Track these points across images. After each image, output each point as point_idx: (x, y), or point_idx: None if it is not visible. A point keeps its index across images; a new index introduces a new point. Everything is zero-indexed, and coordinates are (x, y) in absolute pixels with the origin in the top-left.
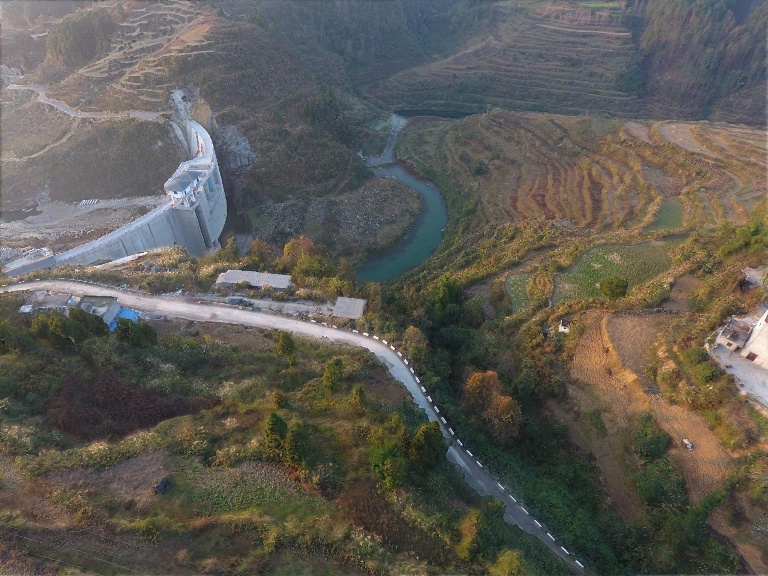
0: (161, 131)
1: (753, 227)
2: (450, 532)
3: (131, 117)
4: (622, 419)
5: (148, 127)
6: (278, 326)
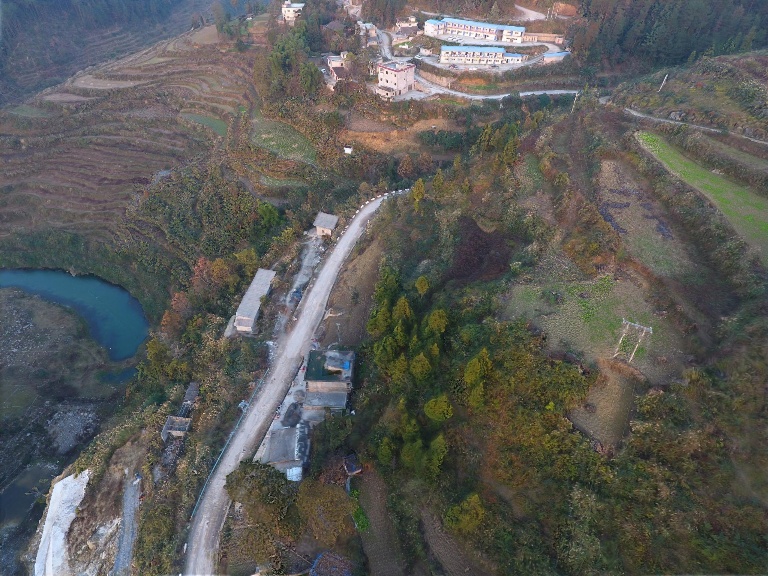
0: None
1: (304, 67)
2: (526, 131)
3: None
4: (416, 144)
5: None
6: (340, 259)
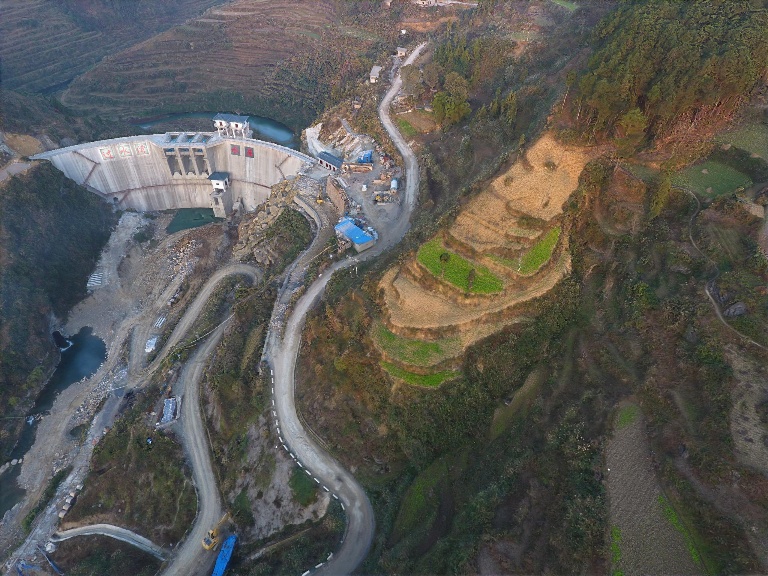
0: (55, 168)
1: None
2: None
3: (6, 179)
4: None
5: (43, 171)
6: (412, 60)
